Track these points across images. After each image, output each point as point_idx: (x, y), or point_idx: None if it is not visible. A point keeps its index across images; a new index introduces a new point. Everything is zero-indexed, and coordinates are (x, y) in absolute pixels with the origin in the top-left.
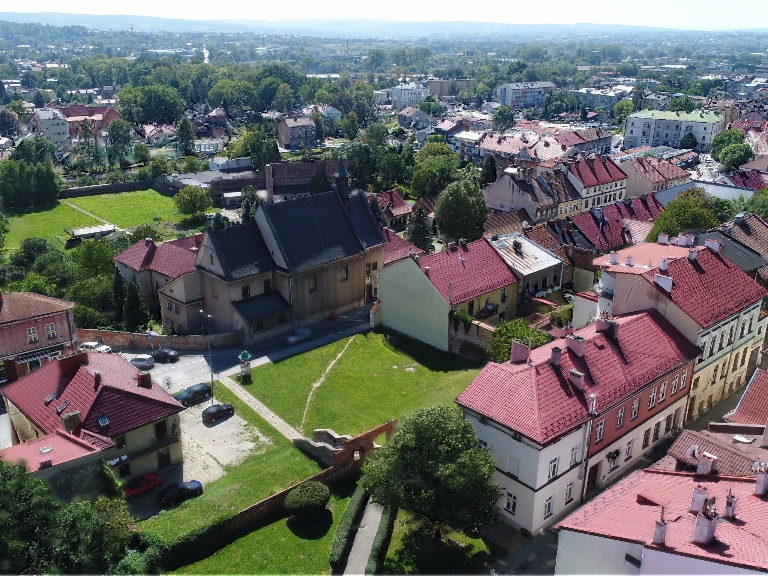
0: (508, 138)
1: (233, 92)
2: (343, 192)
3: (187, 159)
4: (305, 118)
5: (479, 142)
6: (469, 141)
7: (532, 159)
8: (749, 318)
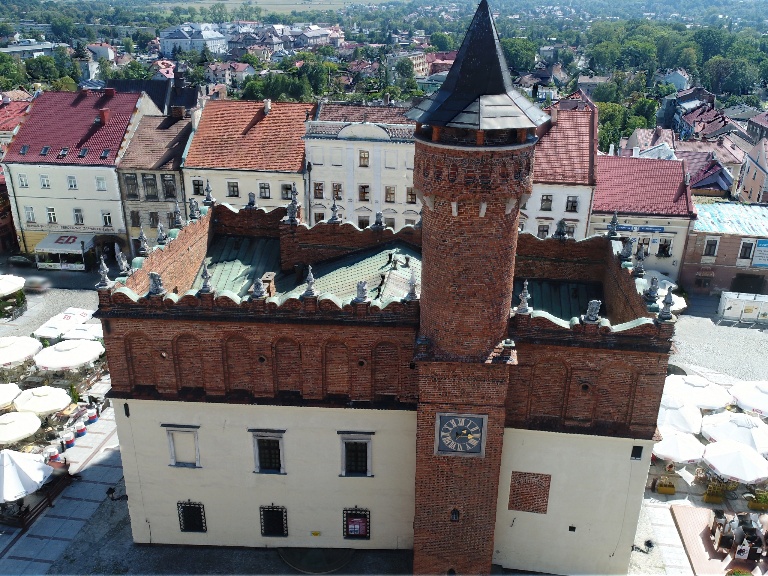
0: (711, 110)
1: (614, 51)
2: (176, 83)
3: (414, 92)
4: (604, 76)
5: (690, 112)
6: (682, 110)
7: (695, 134)
8: (3, 144)
